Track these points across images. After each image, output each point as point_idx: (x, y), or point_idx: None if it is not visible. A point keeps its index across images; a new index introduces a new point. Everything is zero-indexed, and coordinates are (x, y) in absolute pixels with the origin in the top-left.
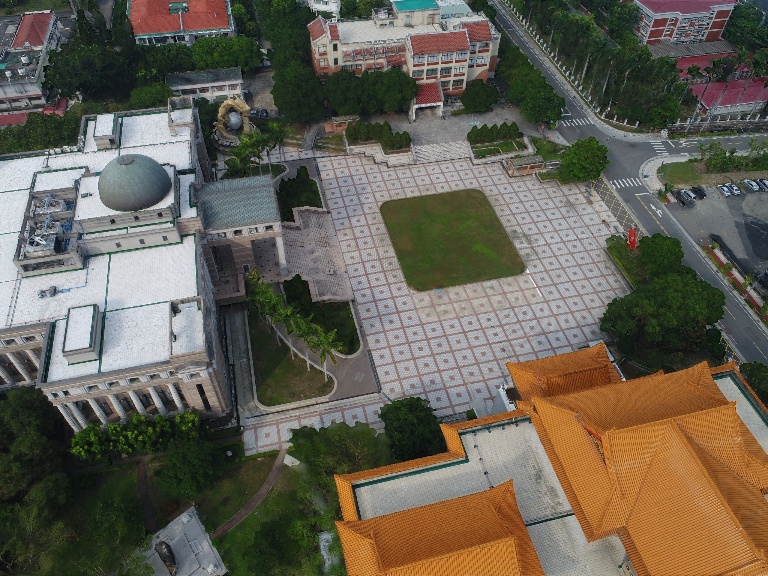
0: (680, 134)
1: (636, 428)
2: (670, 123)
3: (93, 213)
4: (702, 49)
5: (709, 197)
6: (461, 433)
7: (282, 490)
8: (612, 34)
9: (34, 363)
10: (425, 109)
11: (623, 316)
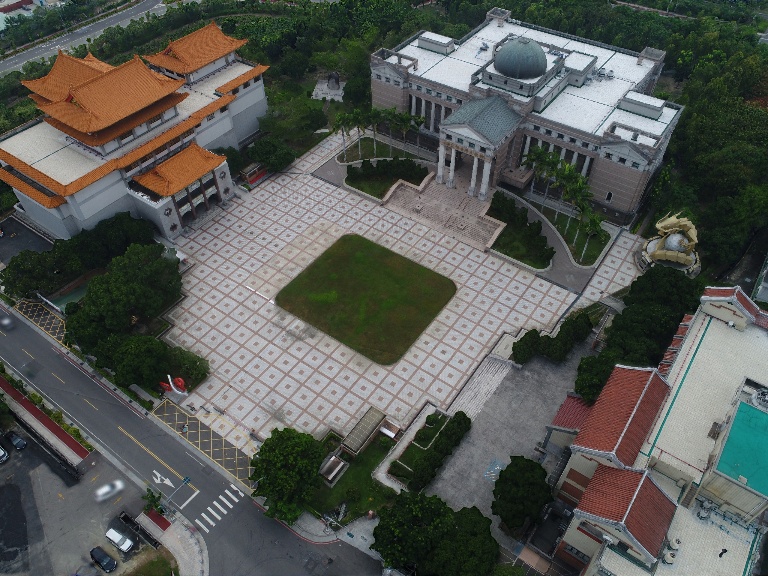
0: None
1: (124, 65)
2: None
3: None
4: None
5: None
6: None
7: None
8: None
9: None
10: None
11: None
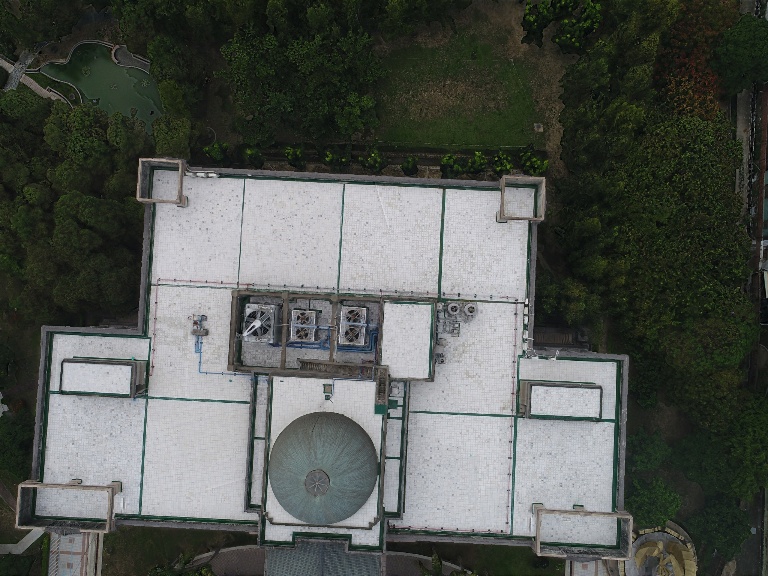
0: None
1: None
2: None
3: (283, 402)
4: None
5: None
6: None
7: (6, 520)
8: None
9: None
10: None
11: None
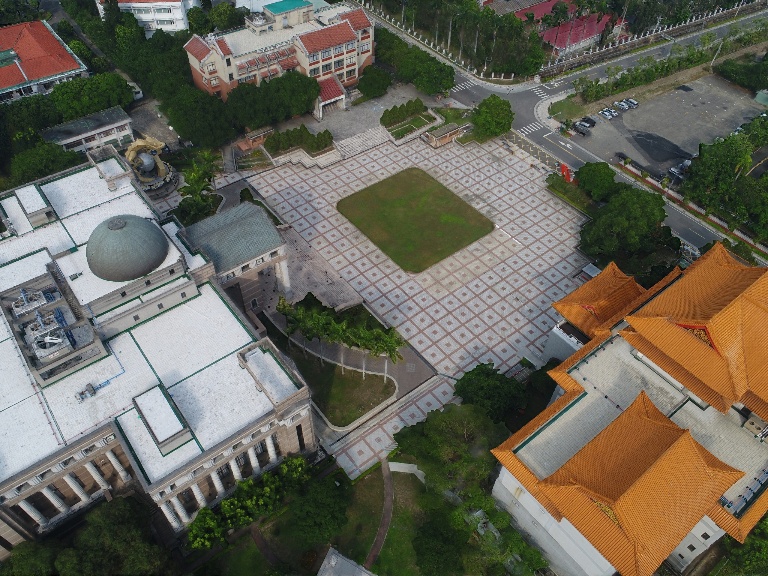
0: (549, 77)
1: (725, 309)
2: (539, 69)
3: (97, 292)
4: (528, 1)
5: (598, 123)
6: (567, 373)
7: (405, 495)
8: (452, 2)
9: (82, 478)
10: (327, 105)
11: (602, 237)
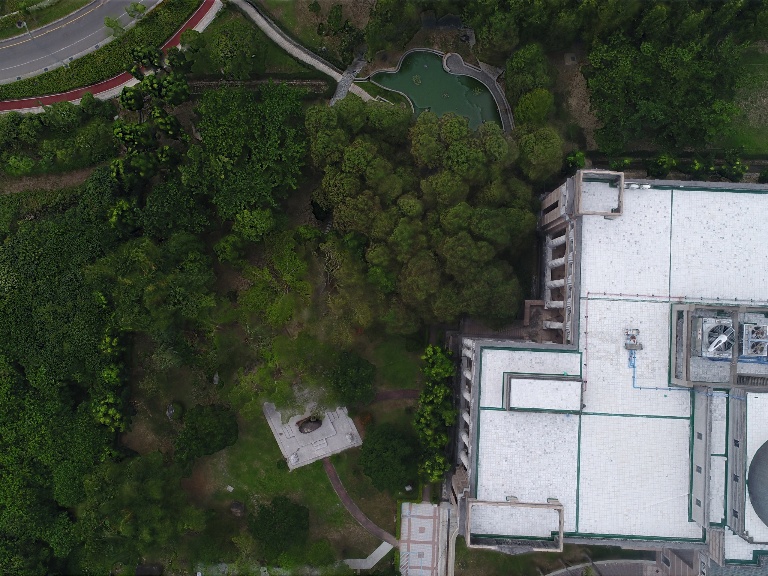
0: None
1: None
2: None
3: (758, 419)
4: None
5: None
6: None
7: (355, 535)
8: None
9: None
10: None
11: None
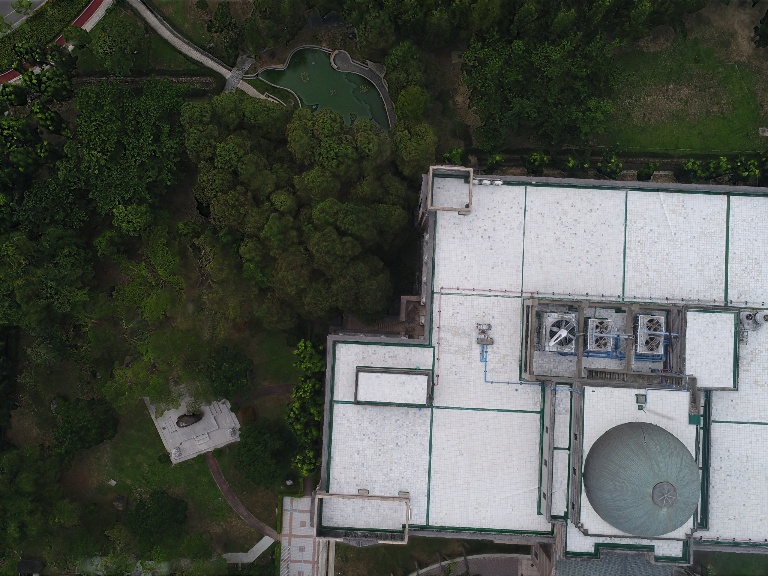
0: None
1: None
2: None
3: (595, 412)
4: None
5: None
6: None
7: (236, 529)
8: None
9: None
10: None
11: None
